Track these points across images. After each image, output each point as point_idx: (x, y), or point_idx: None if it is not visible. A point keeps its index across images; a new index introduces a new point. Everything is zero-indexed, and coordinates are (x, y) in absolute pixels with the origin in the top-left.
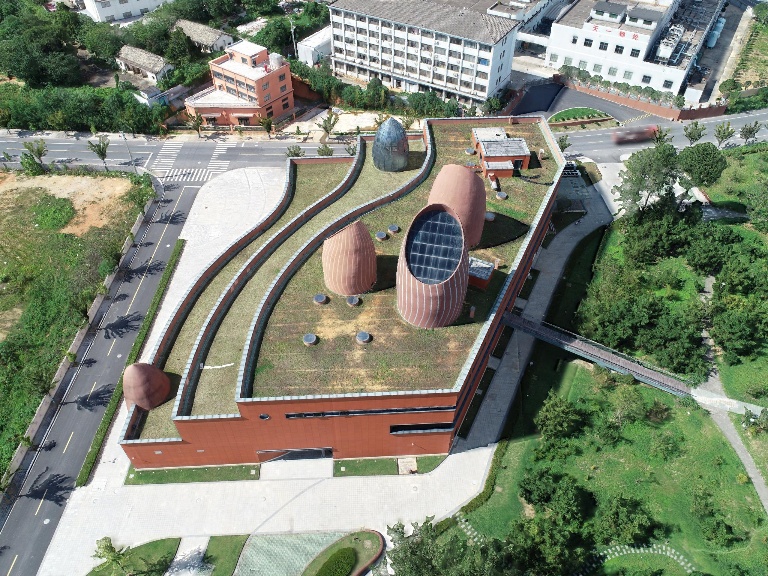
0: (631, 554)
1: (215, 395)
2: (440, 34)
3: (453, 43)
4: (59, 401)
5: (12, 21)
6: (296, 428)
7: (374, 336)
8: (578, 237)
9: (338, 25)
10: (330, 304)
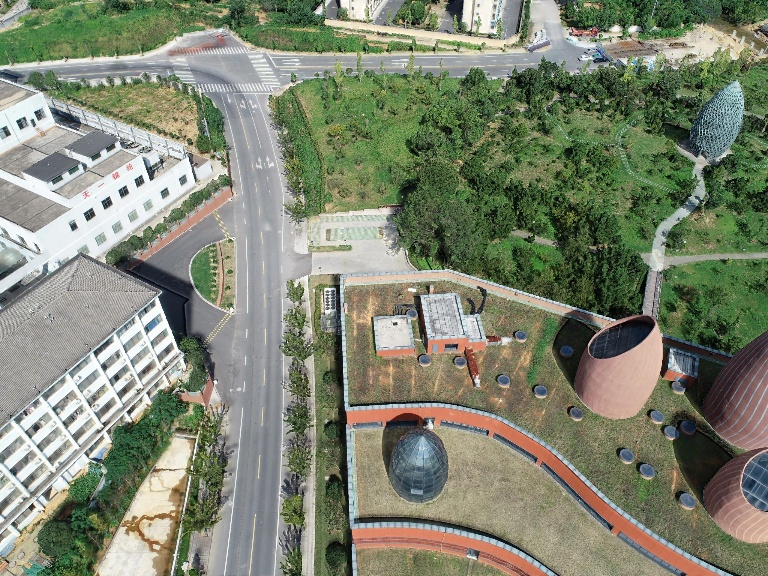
0: None
1: None
2: None
3: (100, 353)
4: None
5: None
6: None
7: None
8: None
9: None
10: None
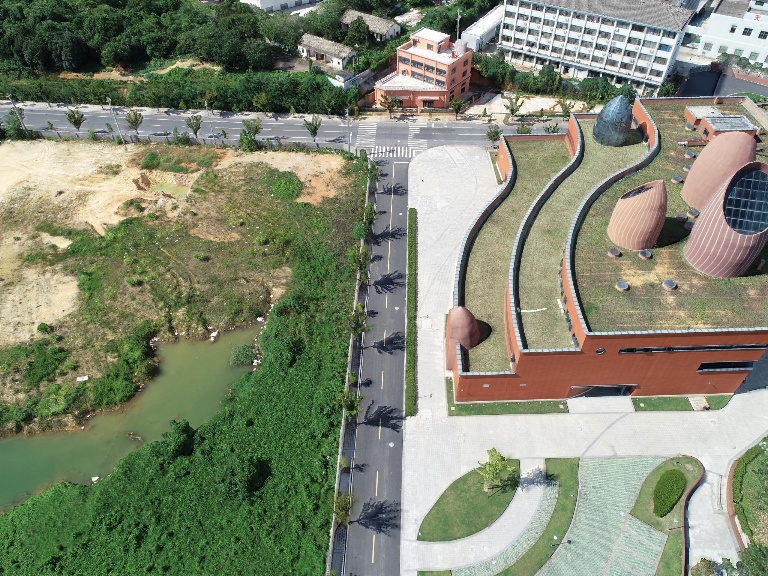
0: None
1: (543, 334)
2: (622, 22)
3: (634, 30)
4: (360, 345)
5: (186, 11)
6: (619, 363)
7: (677, 284)
8: None
9: (510, 14)
10: (624, 257)
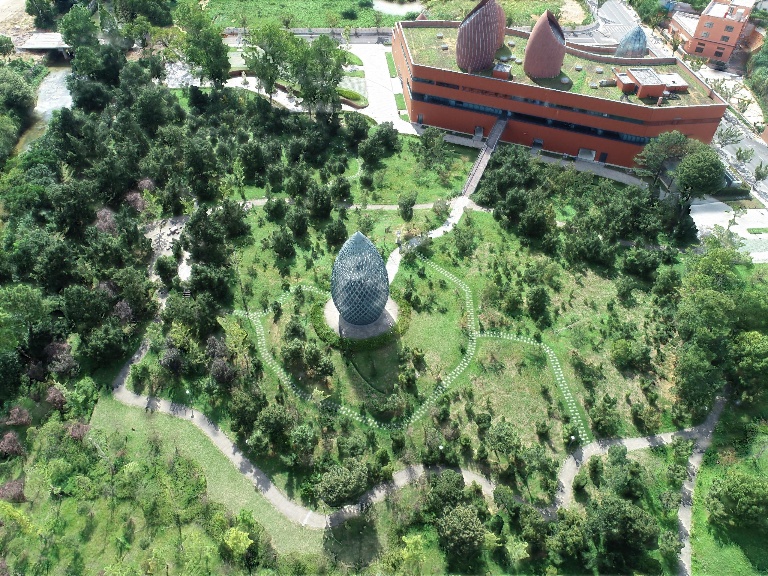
0: (358, 164)
1: None
2: None
3: None
4: None
5: None
6: None
7: (447, 50)
8: (629, 184)
9: None
10: None
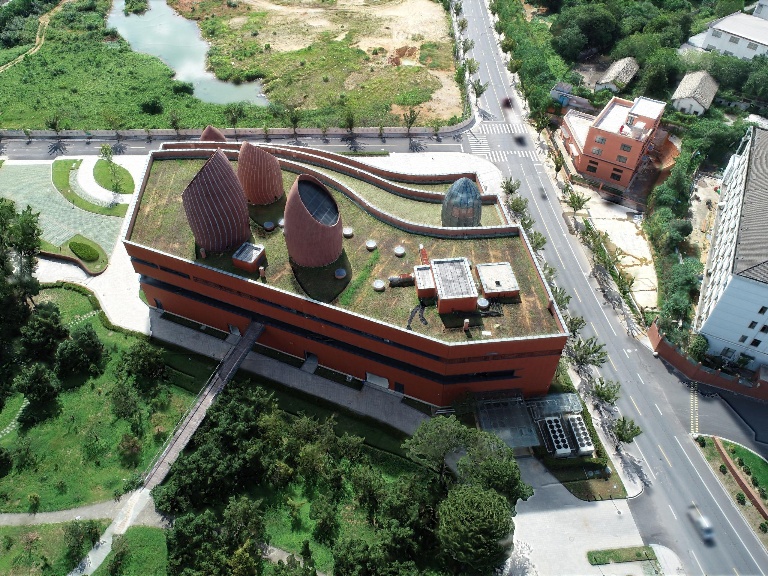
0: (21, 404)
1: None
2: None
3: None
4: (238, 137)
5: (647, 7)
6: None
7: None
8: None
9: None
10: None
